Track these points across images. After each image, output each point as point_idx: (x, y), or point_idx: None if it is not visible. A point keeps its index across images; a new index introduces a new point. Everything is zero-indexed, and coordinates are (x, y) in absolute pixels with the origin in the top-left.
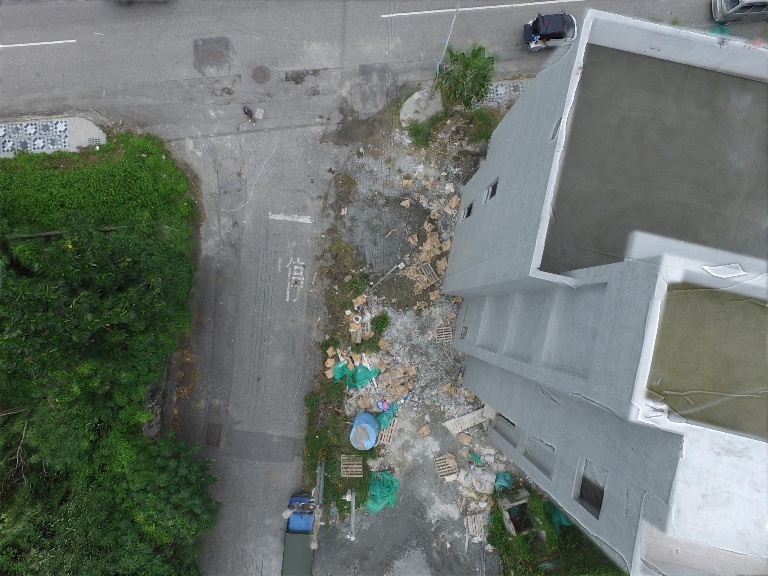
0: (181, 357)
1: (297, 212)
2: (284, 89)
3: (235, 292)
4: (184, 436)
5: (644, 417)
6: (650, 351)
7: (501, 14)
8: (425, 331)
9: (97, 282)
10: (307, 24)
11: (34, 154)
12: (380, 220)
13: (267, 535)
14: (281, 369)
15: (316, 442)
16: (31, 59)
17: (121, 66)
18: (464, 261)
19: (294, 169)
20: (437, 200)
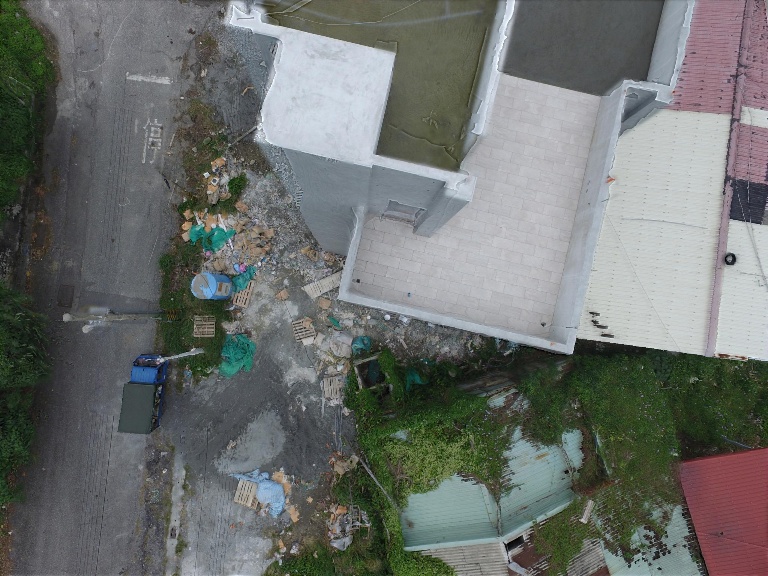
0: (34, 219)
1: (155, 73)
2: None
3: (90, 153)
4: (36, 298)
5: (236, 19)
6: (300, 5)
7: None
8: (285, 194)
9: None
10: None
11: None
12: (237, 78)
13: (118, 396)
14: (136, 231)
15: (171, 304)
16: None
17: None
18: None
19: (153, 29)
20: None
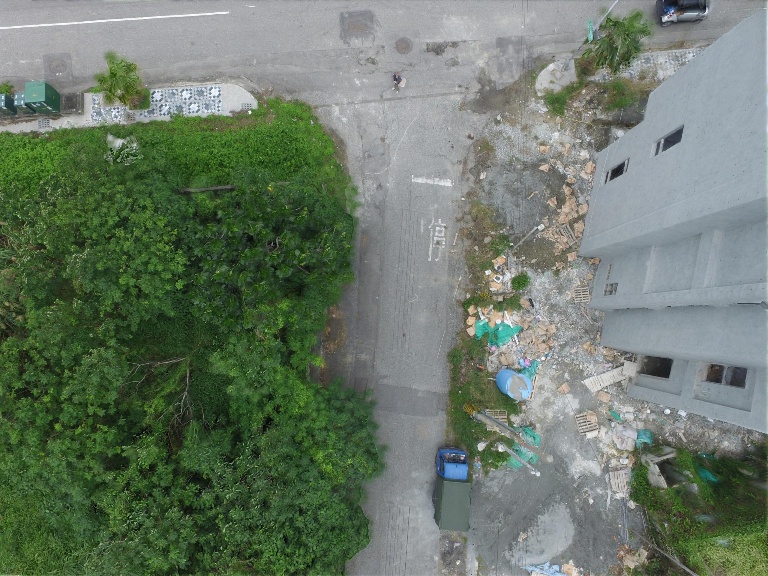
0: (327, 313)
1: (438, 176)
2: (425, 59)
3: (379, 251)
4: None
5: None
6: None
7: None
8: (563, 291)
9: (286, 225)
10: None
11: (190, 117)
12: (522, 183)
13: (413, 488)
14: (424, 326)
15: (459, 397)
16: (187, 29)
17: (271, 36)
18: (627, 213)
19: (435, 135)
20: (573, 166)
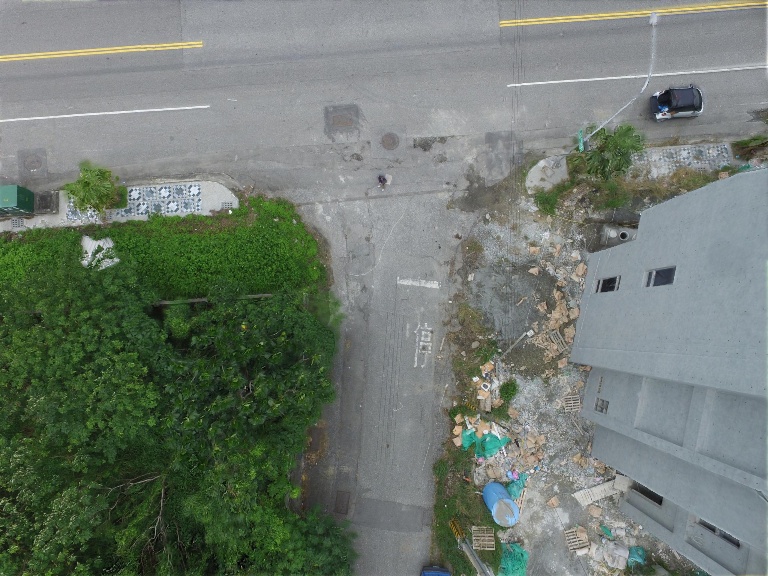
0: None
1: (425, 277)
2: (412, 156)
3: (363, 357)
4: (311, 503)
5: None
6: None
7: (625, 85)
8: (553, 399)
9: (262, 359)
10: (435, 93)
11: (168, 217)
12: (510, 288)
13: None
14: (409, 436)
15: (445, 512)
16: (166, 124)
17: (253, 131)
18: (618, 340)
19: (422, 234)
20: (564, 267)
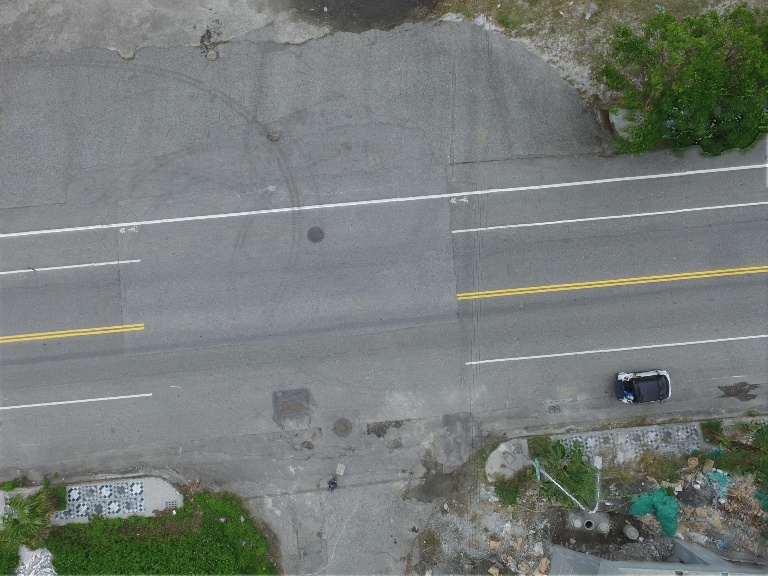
0: None
1: (380, 575)
2: (366, 443)
3: None
4: None
5: None
6: None
7: (589, 360)
8: None
9: None
10: (389, 373)
11: (109, 521)
12: None
13: None
14: None
15: None
16: (106, 415)
17: (198, 421)
18: None
19: (376, 529)
20: (526, 562)
